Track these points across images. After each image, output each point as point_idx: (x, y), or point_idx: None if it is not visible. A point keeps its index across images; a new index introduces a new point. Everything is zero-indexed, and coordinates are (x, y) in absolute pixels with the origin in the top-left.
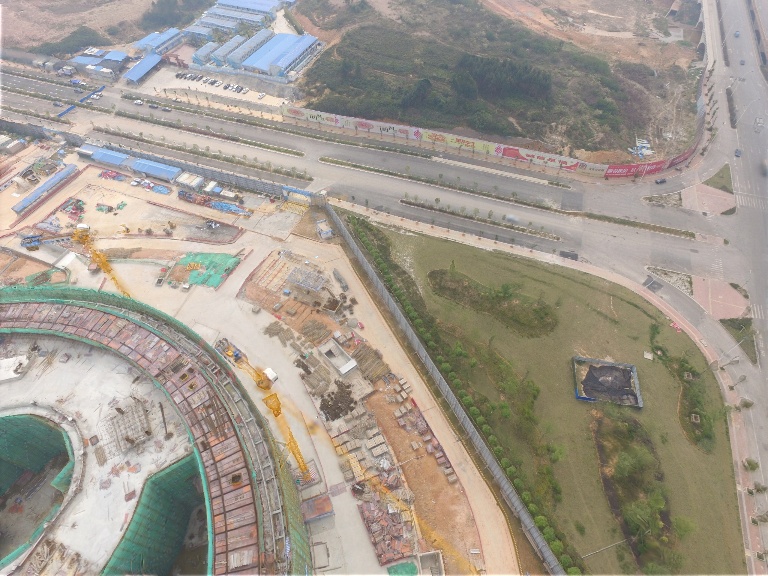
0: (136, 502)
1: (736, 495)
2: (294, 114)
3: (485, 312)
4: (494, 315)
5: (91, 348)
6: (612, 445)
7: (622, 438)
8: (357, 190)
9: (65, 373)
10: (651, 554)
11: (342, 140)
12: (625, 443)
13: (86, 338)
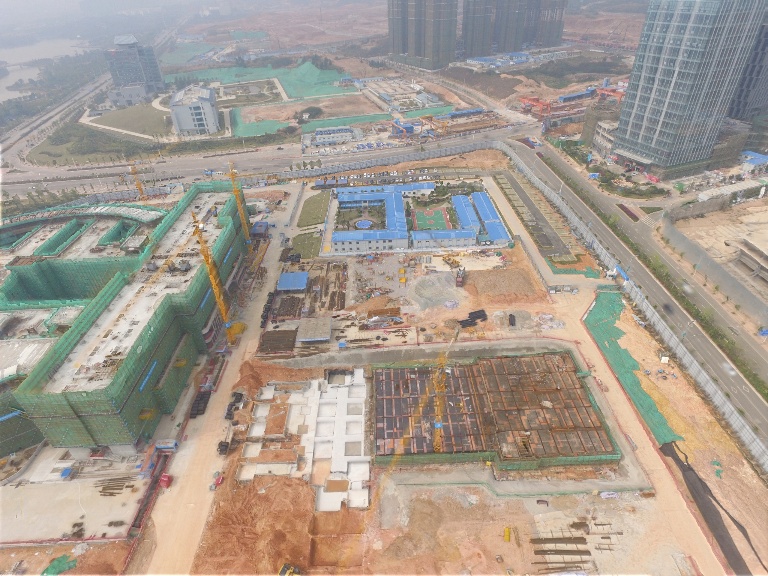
0: None
1: None
2: None
3: None
4: None
5: None
6: None
7: (8, 212)
8: None
9: None
10: None
11: None
12: (10, 212)
13: None
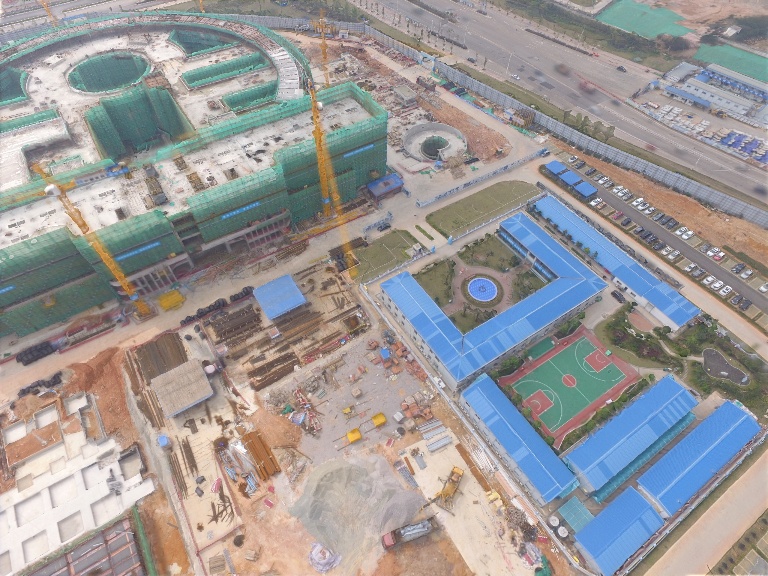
0: (171, 46)
1: (346, 0)
2: (9, 4)
3: (225, 7)
4: (230, 6)
5: (81, 43)
6: (304, 7)
7: (305, 4)
8: (106, 11)
9: (83, 51)
10: (335, 15)
11: (63, 2)
12: (307, 5)
13: (78, 32)
